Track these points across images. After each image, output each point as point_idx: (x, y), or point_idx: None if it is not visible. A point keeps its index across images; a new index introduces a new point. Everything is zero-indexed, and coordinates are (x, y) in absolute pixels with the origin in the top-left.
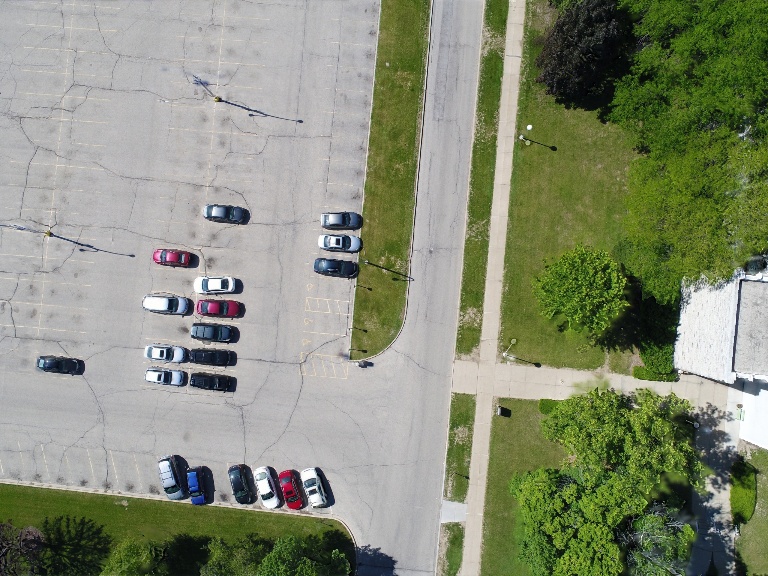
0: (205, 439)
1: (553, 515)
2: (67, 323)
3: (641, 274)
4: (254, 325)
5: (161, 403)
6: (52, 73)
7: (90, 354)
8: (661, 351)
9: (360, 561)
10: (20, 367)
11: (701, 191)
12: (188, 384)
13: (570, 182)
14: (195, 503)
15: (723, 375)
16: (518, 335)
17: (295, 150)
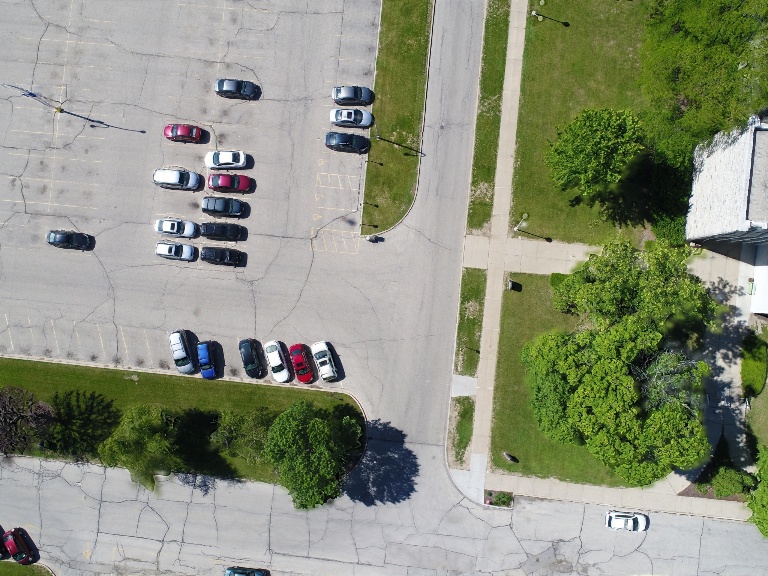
0: (215, 314)
1: (567, 355)
2: (78, 199)
3: (654, 134)
4: (265, 200)
5: (171, 278)
6: None
7: (100, 230)
8: (673, 222)
9: (370, 435)
10: (30, 243)
11: (717, 35)
12: (199, 259)
13: (582, 58)
14: (205, 377)
15: (737, 224)
16: (529, 210)
17: (307, 26)
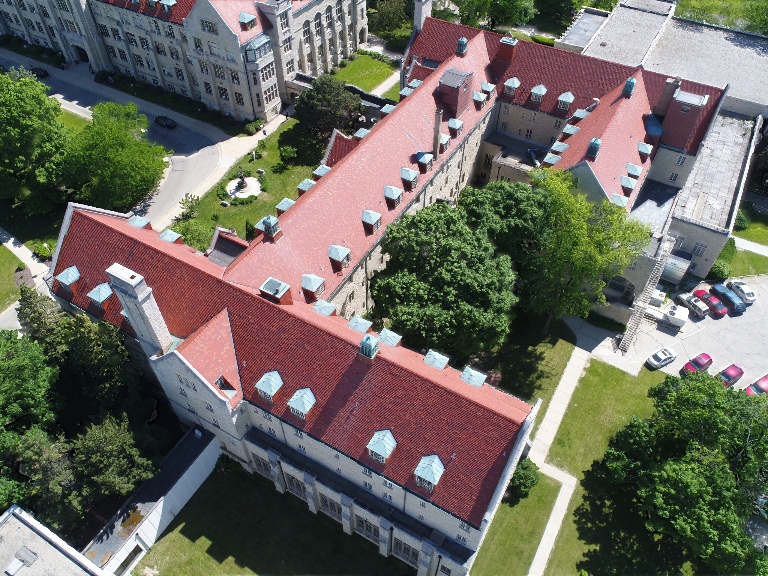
0: None
1: None
2: None
3: None
4: None
5: None
6: None
7: None
8: None
9: None
10: None
11: None
12: None
13: None
14: None
15: None
16: None
17: None
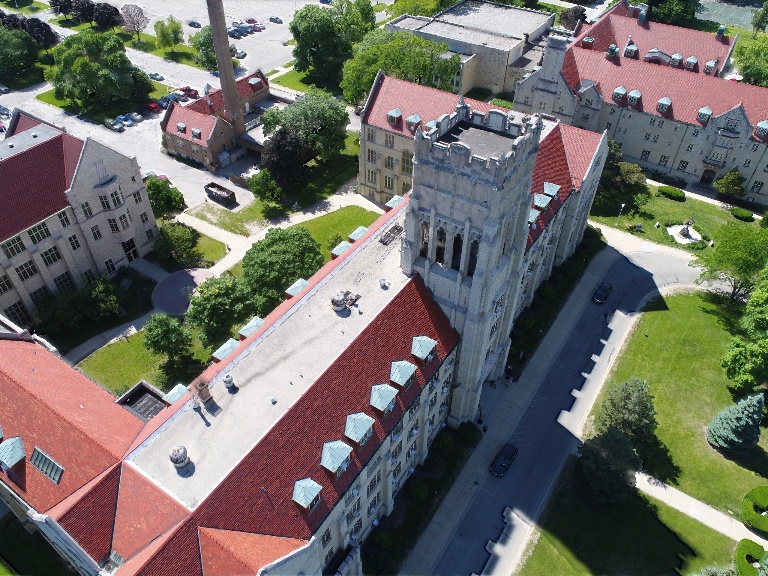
0: None
1: None
2: None
3: None
4: None
5: None
6: (257, 0)
7: None
8: None
9: (236, 68)
10: None
11: None
12: None
13: None
14: None
15: None
16: None
17: None
